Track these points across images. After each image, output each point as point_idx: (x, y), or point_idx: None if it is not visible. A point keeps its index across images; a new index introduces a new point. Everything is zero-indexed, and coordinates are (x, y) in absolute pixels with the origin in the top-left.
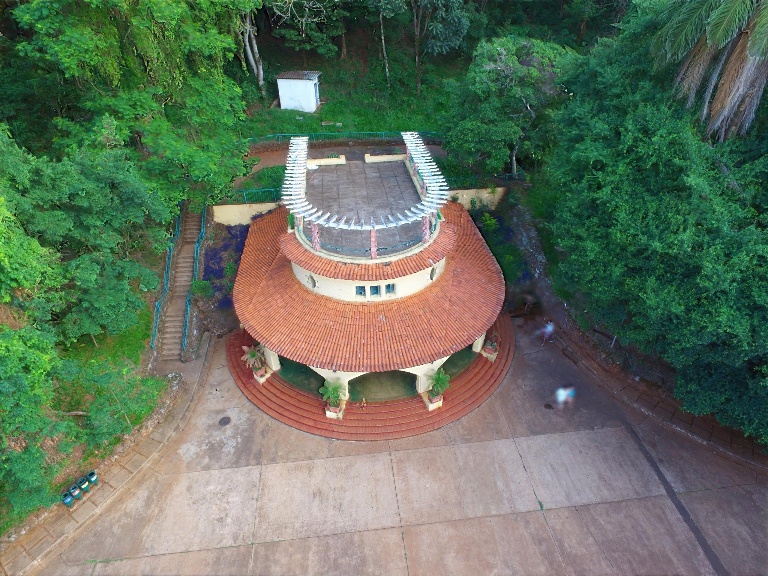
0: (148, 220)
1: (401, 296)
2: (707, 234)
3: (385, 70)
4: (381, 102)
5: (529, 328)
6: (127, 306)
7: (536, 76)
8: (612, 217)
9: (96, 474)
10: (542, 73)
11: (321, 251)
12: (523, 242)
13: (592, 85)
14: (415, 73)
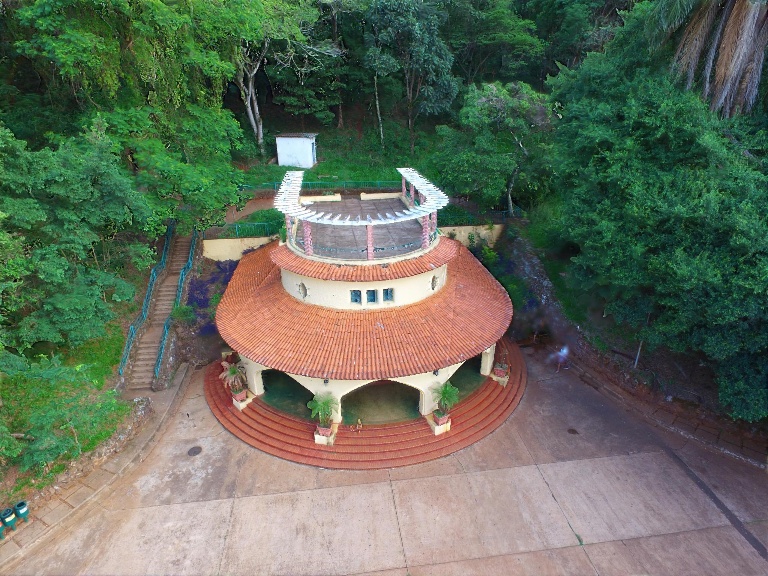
0: (131, 236)
1: (400, 304)
2: (733, 196)
3: (380, 136)
4: (376, 159)
5: (540, 356)
6: (95, 315)
7: (527, 107)
8: (625, 198)
9: (27, 506)
10: (533, 106)
11: (314, 255)
12: (526, 271)
13: (586, 88)
14: (408, 138)
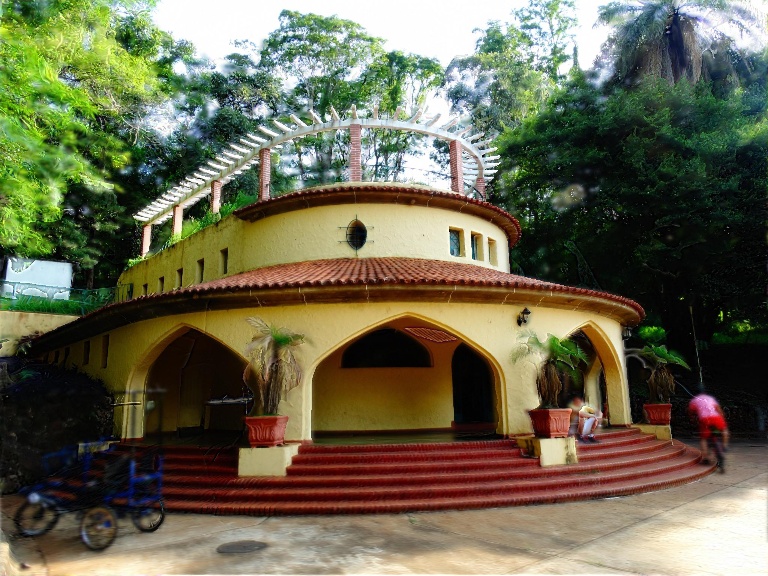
0: None
1: None
2: None
3: None
4: None
5: None
6: None
7: None
8: None
9: None
10: None
11: None
12: None
13: None
14: None
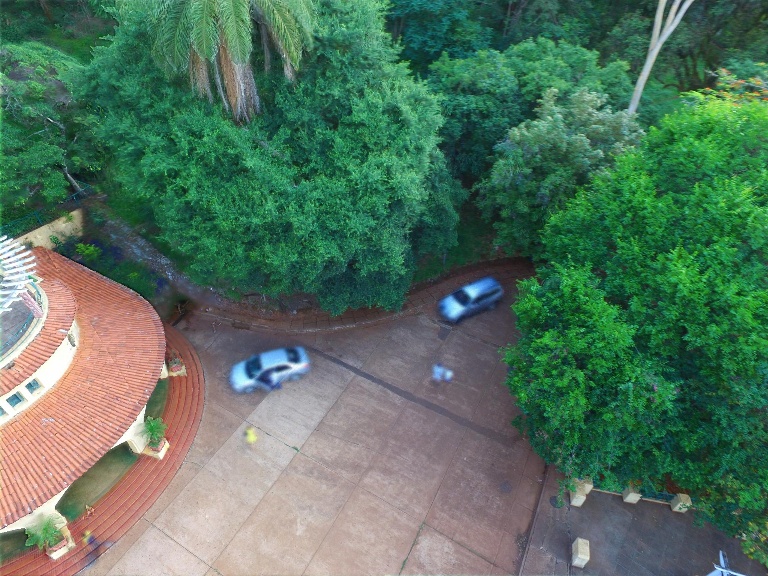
0: None
1: (52, 384)
2: (281, 197)
3: None
4: None
5: (194, 325)
6: None
7: (41, 90)
8: (210, 210)
9: None
10: (45, 84)
11: None
12: (137, 254)
13: (116, 97)
14: None
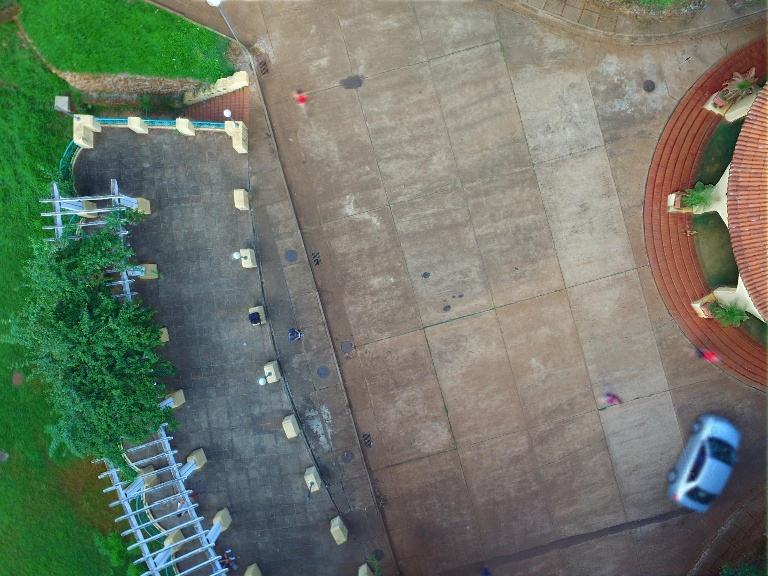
0: None
1: None
2: None
3: None
4: None
5: None
6: None
7: None
8: None
9: None
10: None
11: None
12: None
13: None
14: None
